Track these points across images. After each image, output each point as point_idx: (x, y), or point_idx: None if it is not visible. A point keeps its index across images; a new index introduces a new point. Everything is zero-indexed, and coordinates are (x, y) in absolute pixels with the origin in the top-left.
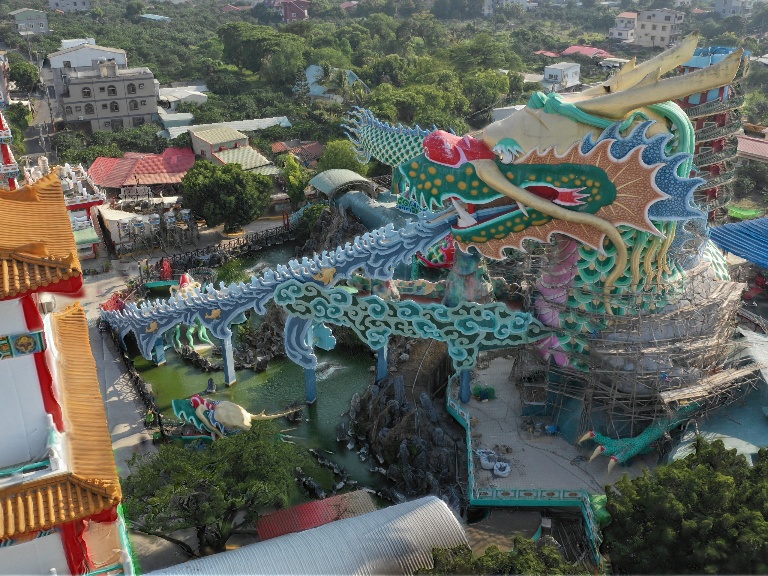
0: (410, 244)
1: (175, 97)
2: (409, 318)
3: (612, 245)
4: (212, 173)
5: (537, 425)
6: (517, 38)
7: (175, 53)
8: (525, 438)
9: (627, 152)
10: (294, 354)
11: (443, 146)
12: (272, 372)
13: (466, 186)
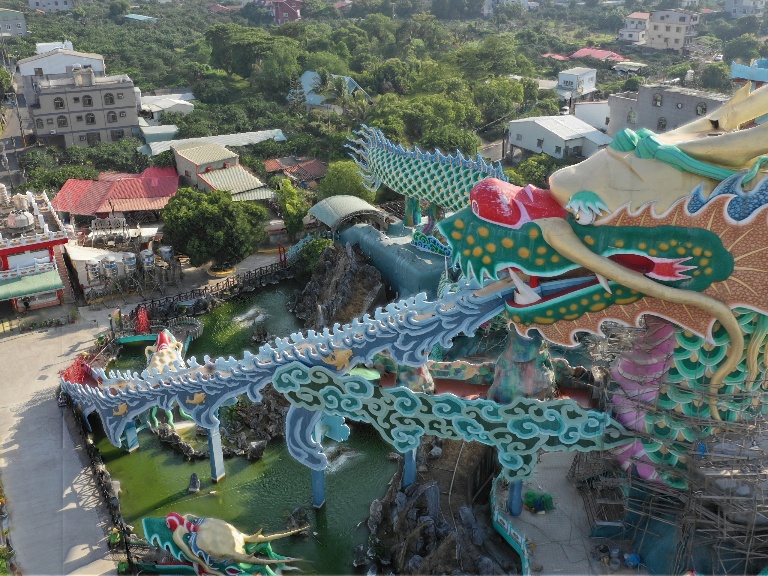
0: (450, 323)
1: (158, 107)
2: (448, 416)
3: (724, 332)
4: (197, 203)
5: (613, 553)
6: (522, 40)
7: (160, 57)
8: (599, 572)
9: (750, 212)
10: (298, 451)
11: (498, 200)
12: (269, 461)
13: (529, 253)
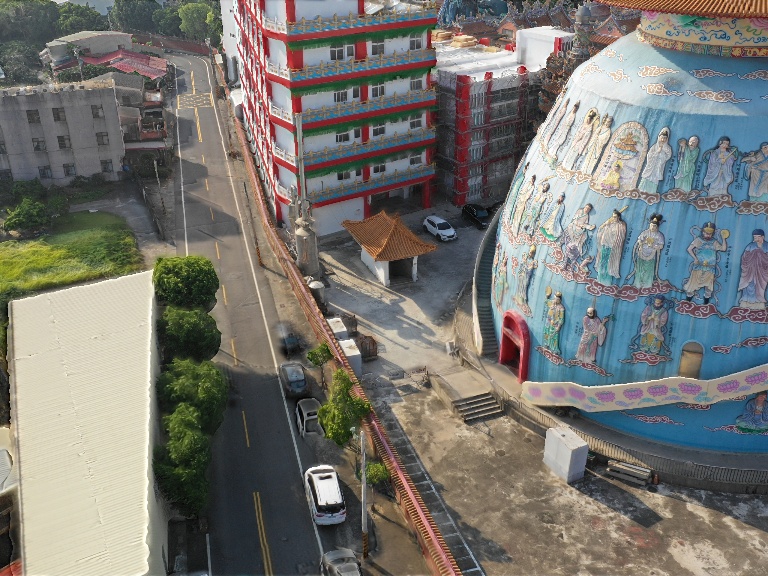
0: None
1: None
2: None
3: None
4: None
5: None
6: None
7: None
8: None
9: None
10: None
11: None
12: None
13: None
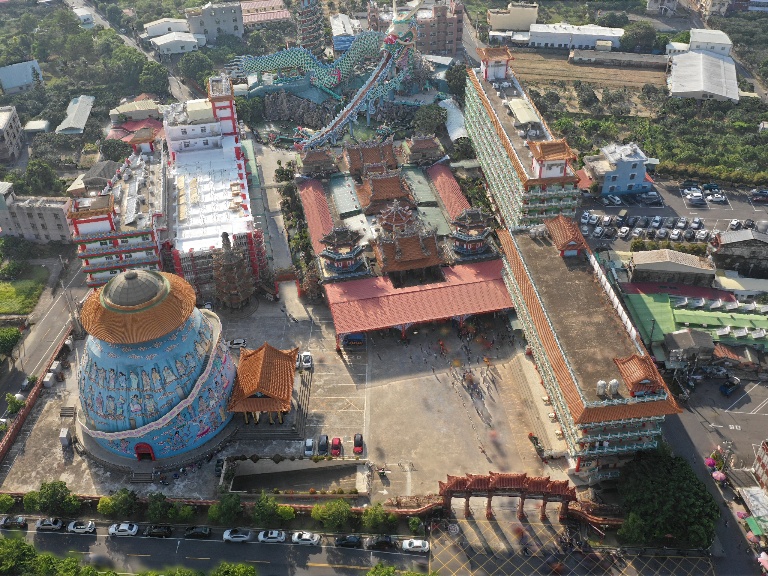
0: None
1: None
2: None
3: None
4: None
5: (411, 95)
6: None
7: None
8: None
9: None
10: None
11: None
12: None
13: None
